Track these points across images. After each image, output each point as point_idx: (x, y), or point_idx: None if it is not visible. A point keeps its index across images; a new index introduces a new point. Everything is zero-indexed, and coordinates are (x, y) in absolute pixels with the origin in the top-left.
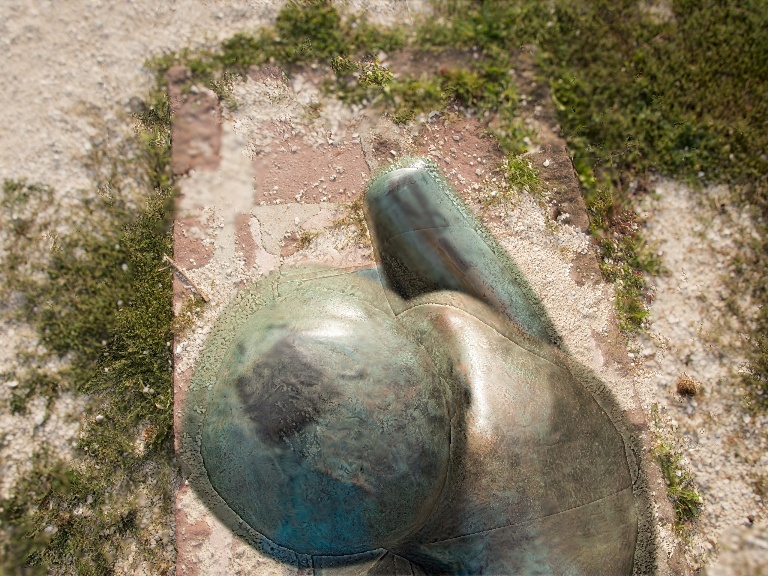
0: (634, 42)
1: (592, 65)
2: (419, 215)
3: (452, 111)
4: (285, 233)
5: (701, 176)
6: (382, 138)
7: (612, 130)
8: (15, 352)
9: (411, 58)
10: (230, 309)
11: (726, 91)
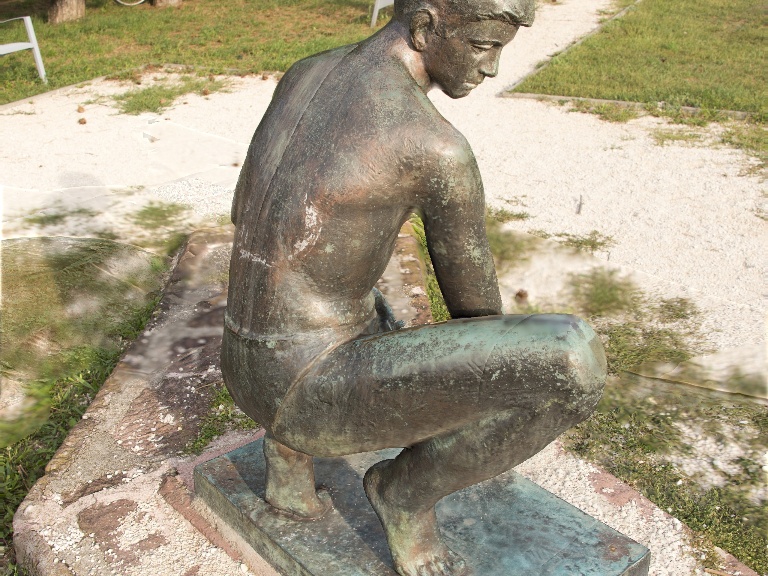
0: None
1: None
2: (539, 321)
3: None
4: None
5: None
6: None
7: None
8: None
9: None
10: (678, 573)
11: None
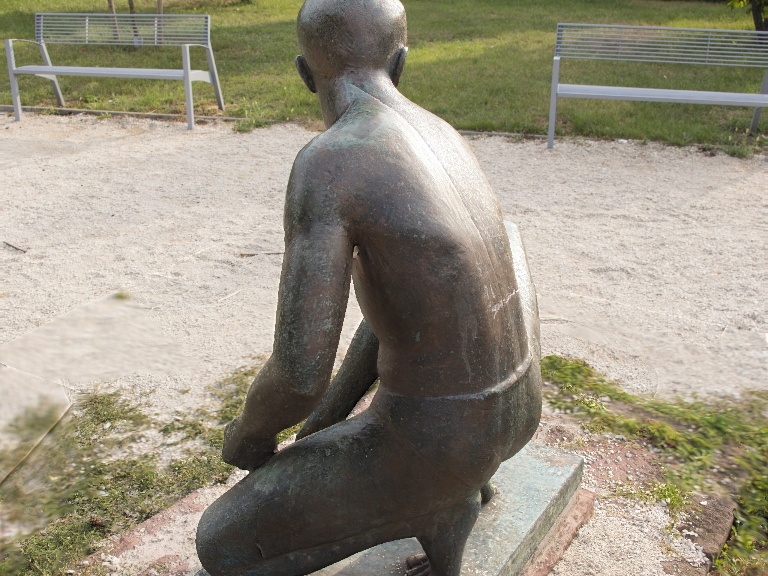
0: None
1: None
2: None
3: (639, 444)
4: None
5: None
6: (563, 429)
7: None
8: (198, 408)
9: (630, 409)
10: None
11: None
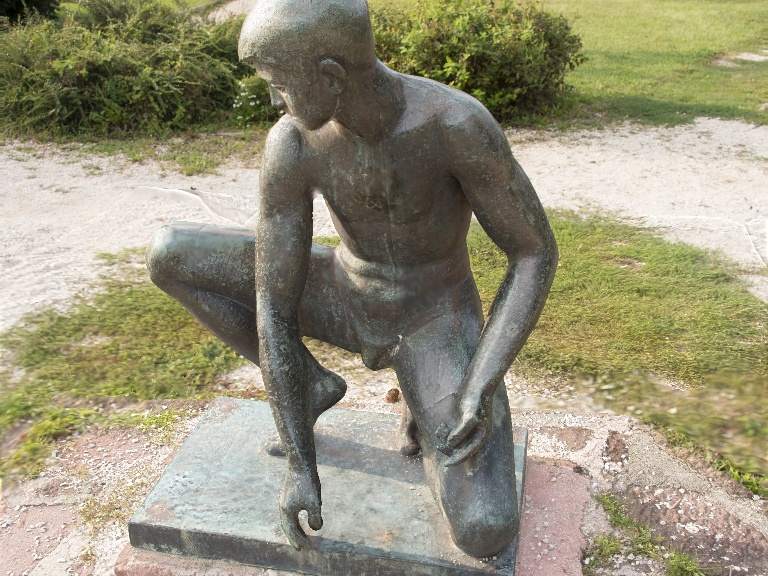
0: (112, 356)
1: (108, 375)
2: (193, 225)
3: (64, 444)
4: (65, 571)
5: (243, 358)
6: (41, 488)
7: (169, 381)
8: None
9: None
10: None
11: (192, 330)
